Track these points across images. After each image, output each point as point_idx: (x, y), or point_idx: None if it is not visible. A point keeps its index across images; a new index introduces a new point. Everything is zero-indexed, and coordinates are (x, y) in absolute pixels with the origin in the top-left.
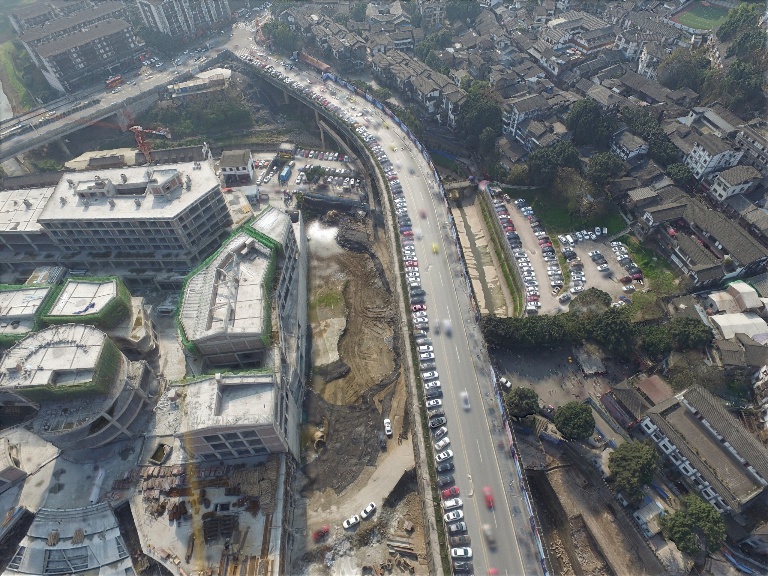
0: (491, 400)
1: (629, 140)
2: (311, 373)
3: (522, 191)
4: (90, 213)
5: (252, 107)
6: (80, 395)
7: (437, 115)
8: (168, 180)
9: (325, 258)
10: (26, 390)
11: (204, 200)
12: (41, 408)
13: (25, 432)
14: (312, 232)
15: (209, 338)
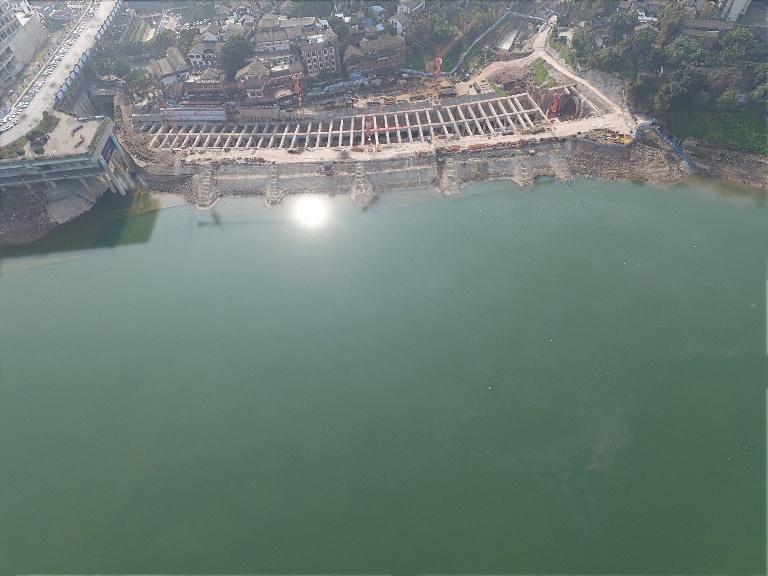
0: None
1: None
2: (21, 77)
3: (181, 10)
4: None
5: None
6: None
7: None
8: None
9: None
10: None
11: None
12: None
13: None
14: (53, 35)
15: None
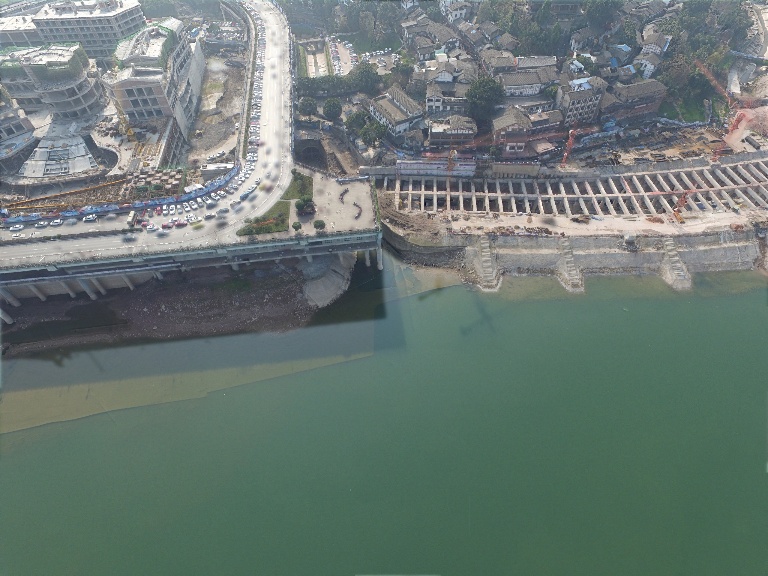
0: (287, 99)
1: None
2: (199, 113)
3: (348, 36)
4: (63, 17)
5: (177, 4)
6: (62, 76)
7: None
8: None
9: (216, 71)
10: (35, 66)
11: (131, 12)
12: (42, 84)
13: (32, 117)
14: (210, 61)
15: (130, 59)
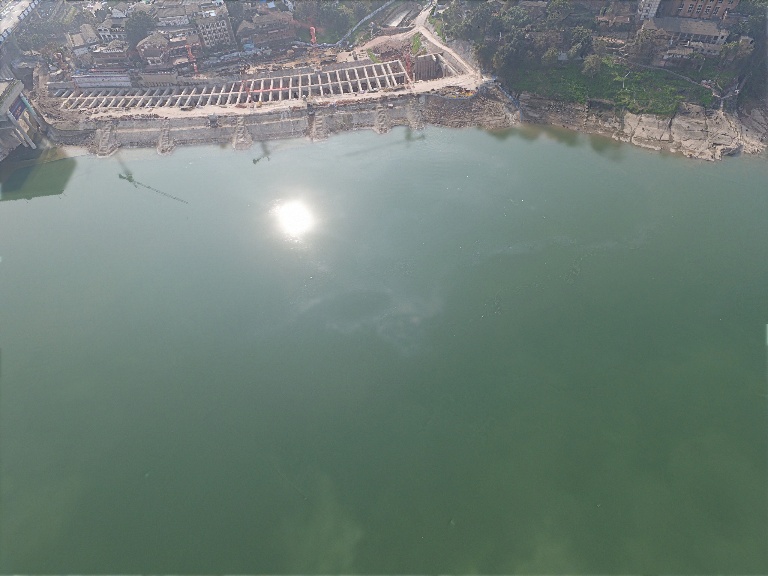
0: None
1: None
2: None
3: None
4: None
5: None
6: None
7: None
8: None
9: None
10: None
11: None
12: None
13: None
14: None
15: None
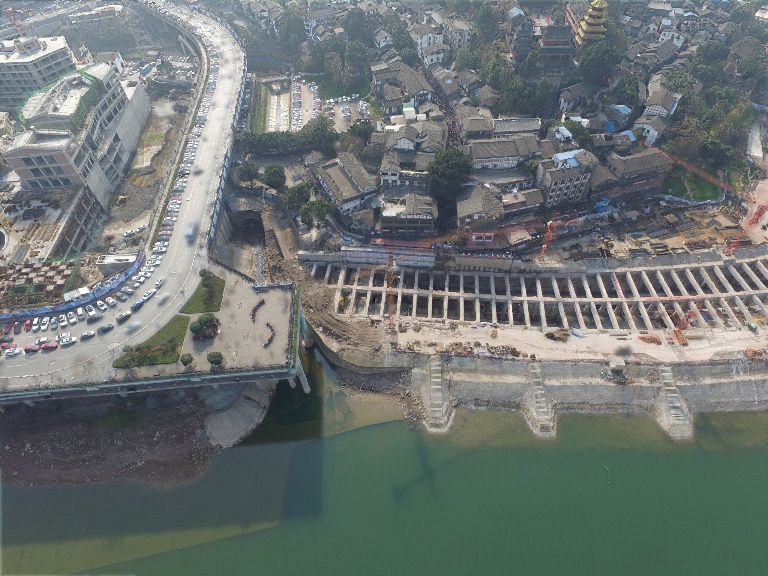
0: None
1: (380, 34)
2: (129, 172)
3: (314, 77)
4: None
5: (137, 32)
6: None
7: (268, 31)
8: (28, 41)
9: (160, 117)
10: None
11: (54, 56)
12: None
13: None
14: (157, 104)
15: (37, 118)
